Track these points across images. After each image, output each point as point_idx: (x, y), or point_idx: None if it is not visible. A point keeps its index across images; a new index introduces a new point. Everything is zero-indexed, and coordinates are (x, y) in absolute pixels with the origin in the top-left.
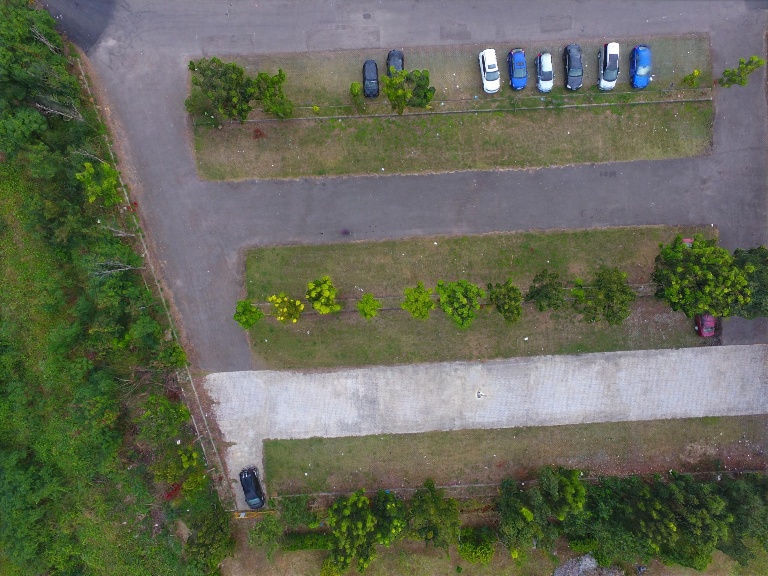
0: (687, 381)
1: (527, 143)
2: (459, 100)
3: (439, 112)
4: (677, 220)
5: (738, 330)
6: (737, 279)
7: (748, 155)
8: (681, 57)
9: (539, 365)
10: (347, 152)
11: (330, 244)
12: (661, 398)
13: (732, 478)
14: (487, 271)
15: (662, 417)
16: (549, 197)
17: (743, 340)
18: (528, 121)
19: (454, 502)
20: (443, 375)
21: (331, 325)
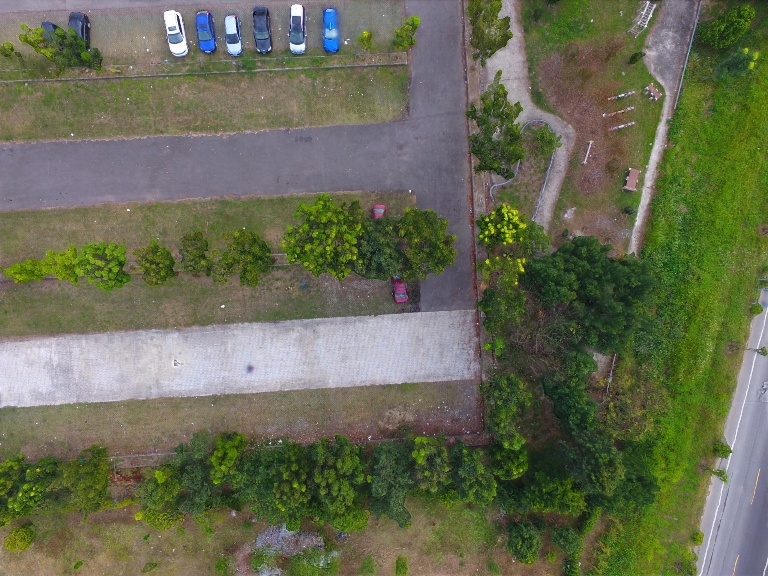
0: (386, 348)
1: (220, 108)
2: (149, 64)
3: (128, 76)
4: (374, 186)
5: (436, 296)
6: (344, 237)
7: (445, 120)
8: (376, 20)
9: (236, 333)
10: (35, 117)
11: (20, 211)
12: (360, 365)
13: None
14: None
15: (361, 384)
16: (244, 163)
17: (441, 306)
18: (221, 85)
19: (101, 466)
20: (139, 343)
21: (23, 293)
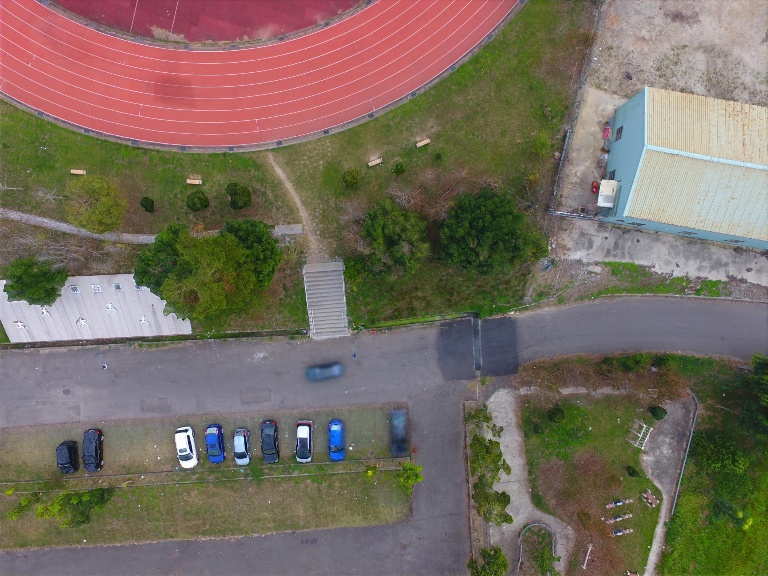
0: None
1: (228, 512)
2: (159, 472)
3: (139, 485)
4: None
5: None
6: None
7: (447, 521)
8: (380, 426)
9: None
10: (48, 524)
11: None
12: None
13: None
14: None
15: None
16: (251, 565)
17: None
18: (229, 491)
19: None
20: None
21: None
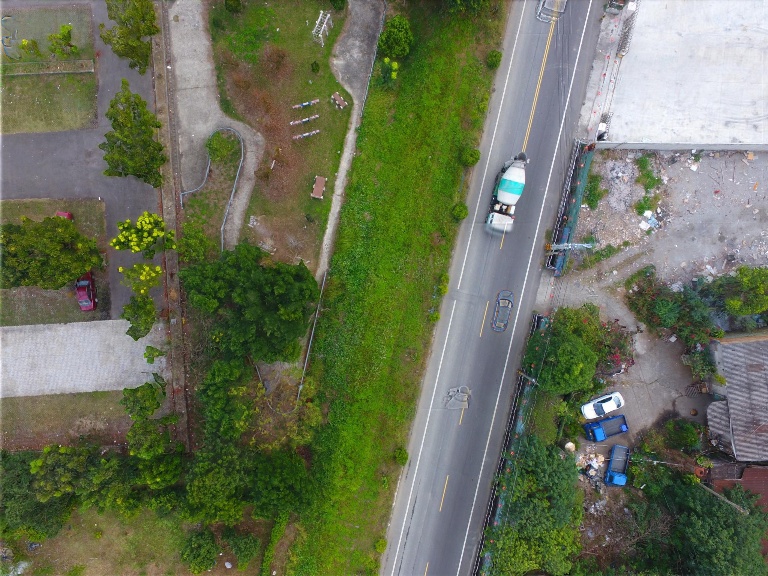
0: (76, 356)
1: None
2: None
3: None
4: (62, 193)
5: None
6: None
7: None
8: None
9: None
10: None
11: None
12: (49, 373)
13: (119, 452)
14: None
15: (51, 392)
16: None
17: None
18: None
19: None
20: None
21: None
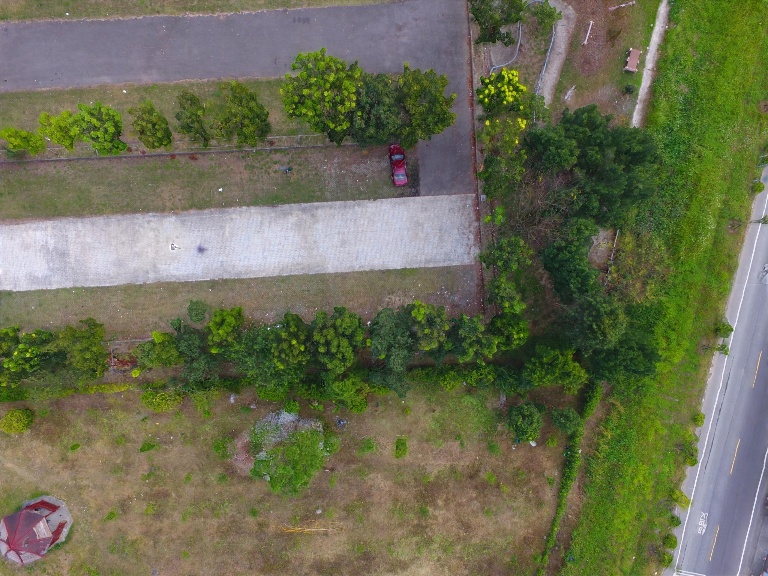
0: (385, 232)
1: None
2: None
3: None
4: (373, 68)
5: (436, 180)
6: (343, 84)
7: (444, 1)
8: None
9: (234, 217)
10: None
11: (14, 92)
12: (359, 250)
13: None
14: None
15: (360, 269)
16: (241, 44)
17: (441, 190)
18: None
19: (97, 332)
20: (135, 227)
21: (18, 176)
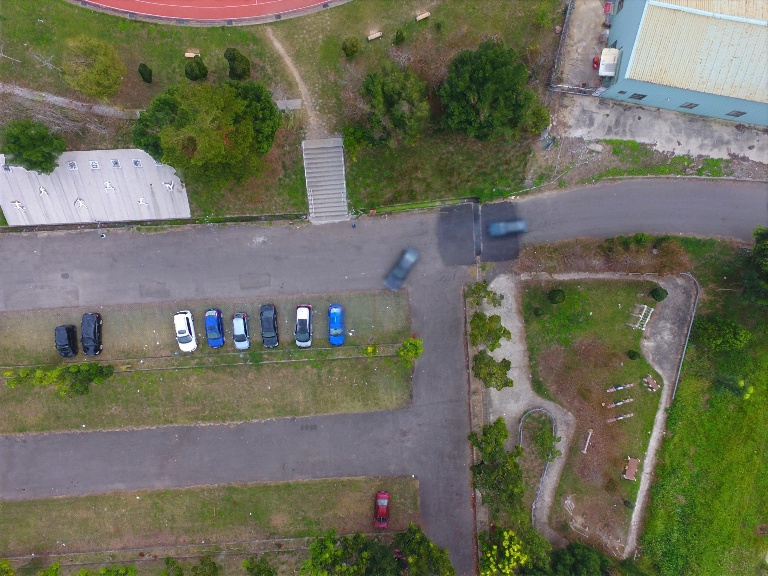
0: None
1: (228, 398)
2: (159, 357)
3: (138, 370)
4: (378, 472)
5: None
6: None
7: (447, 408)
8: (380, 312)
9: None
10: (47, 409)
11: (32, 500)
12: None
13: None
14: (190, 524)
15: None
16: (251, 451)
17: None
18: (229, 376)
19: None
20: None
21: None
